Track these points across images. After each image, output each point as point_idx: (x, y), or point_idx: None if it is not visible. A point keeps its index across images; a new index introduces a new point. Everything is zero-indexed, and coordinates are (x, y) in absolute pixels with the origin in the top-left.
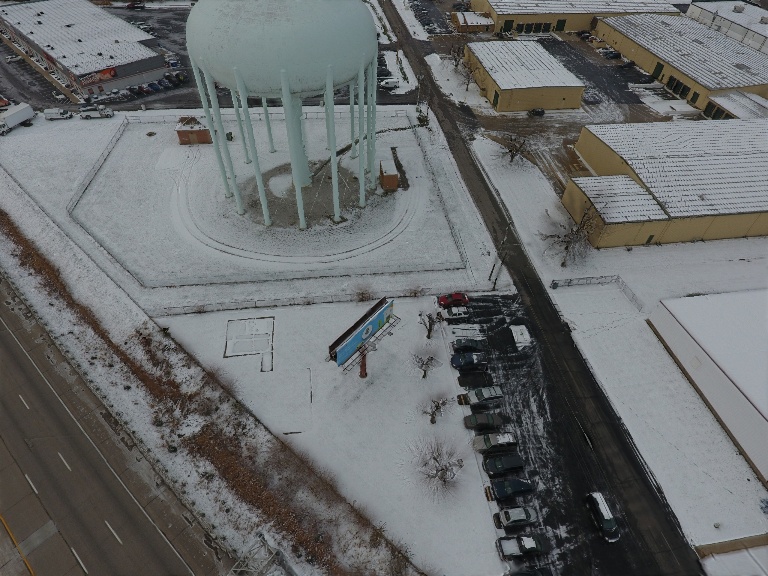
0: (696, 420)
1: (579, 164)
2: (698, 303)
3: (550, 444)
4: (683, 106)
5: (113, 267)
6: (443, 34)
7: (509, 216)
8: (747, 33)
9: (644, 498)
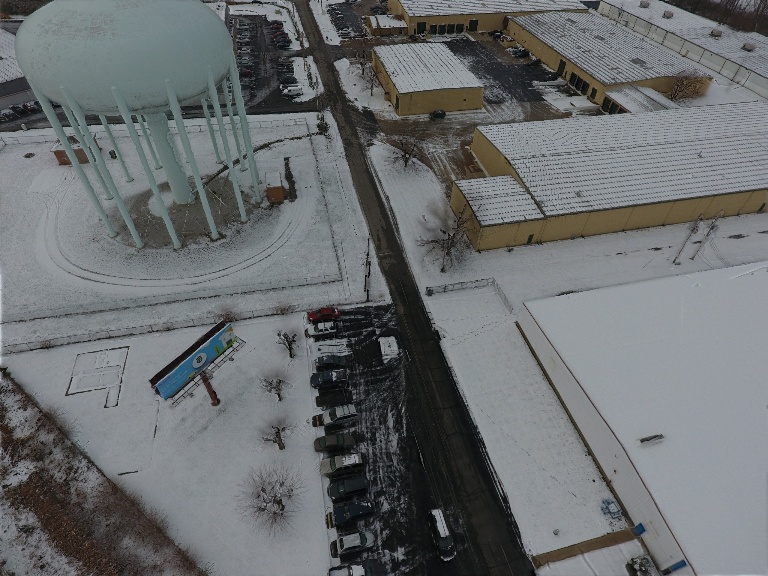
0: (551, 423)
1: (474, 165)
2: (559, 303)
3: (401, 461)
4: (583, 102)
5: None
6: (356, 38)
7: (395, 223)
8: (651, 28)
9: (488, 510)
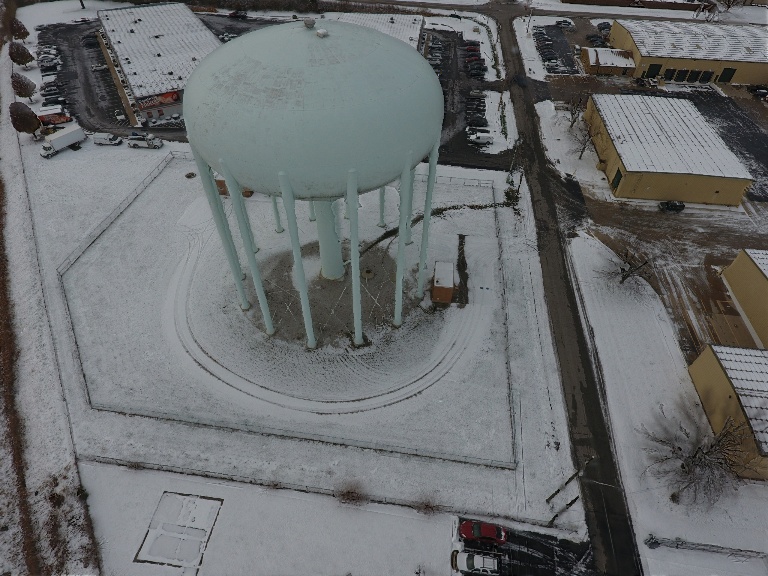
0: None
1: (725, 301)
2: None
3: None
4: None
5: (71, 365)
6: (566, 74)
7: (601, 380)
8: None
9: None
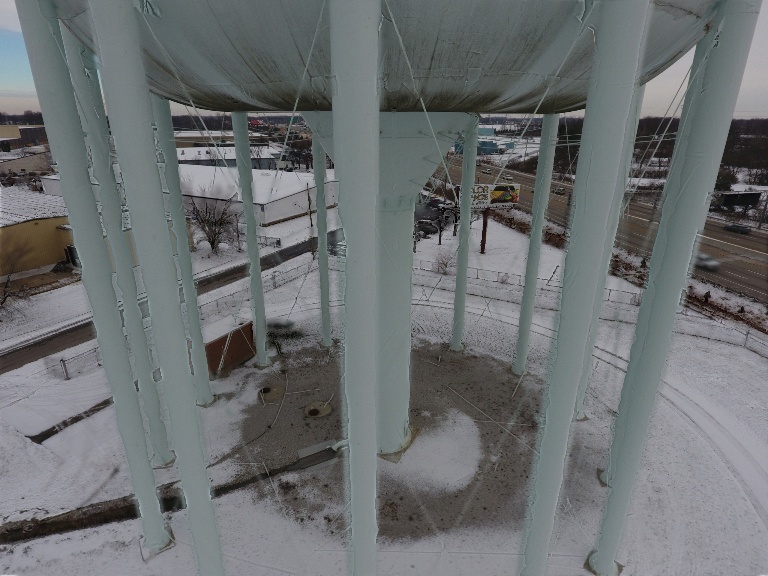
0: None
1: None
2: None
3: None
4: None
5: None
6: None
7: None
8: None
9: None
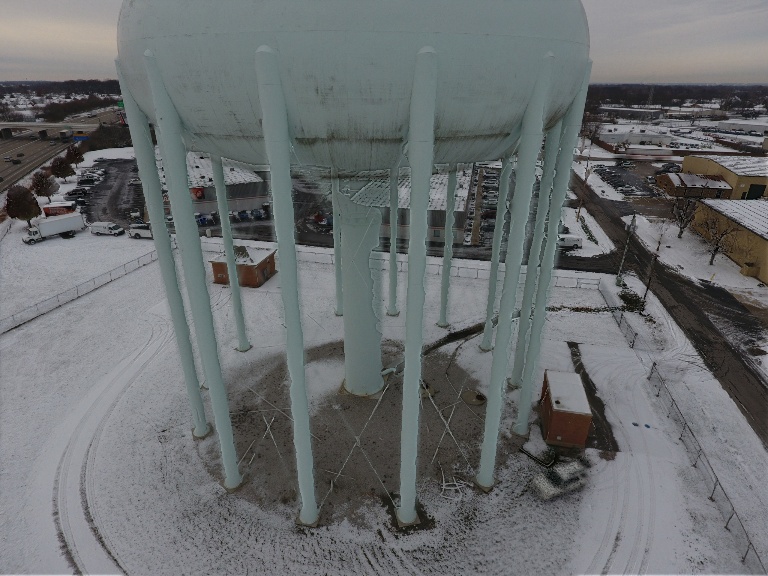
0: None
1: None
2: None
3: None
4: None
5: None
6: (646, 196)
7: None
8: None
9: None
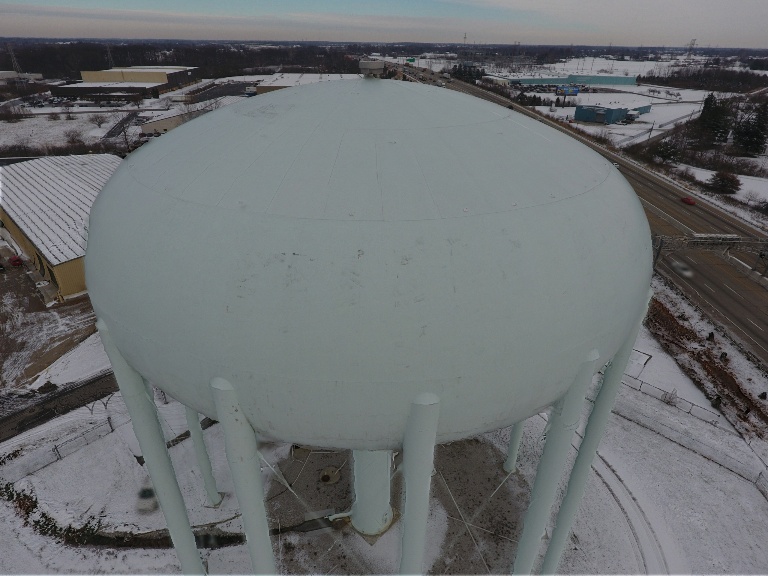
0: None
1: None
2: None
3: None
4: None
5: None
6: None
7: None
8: None
9: None
